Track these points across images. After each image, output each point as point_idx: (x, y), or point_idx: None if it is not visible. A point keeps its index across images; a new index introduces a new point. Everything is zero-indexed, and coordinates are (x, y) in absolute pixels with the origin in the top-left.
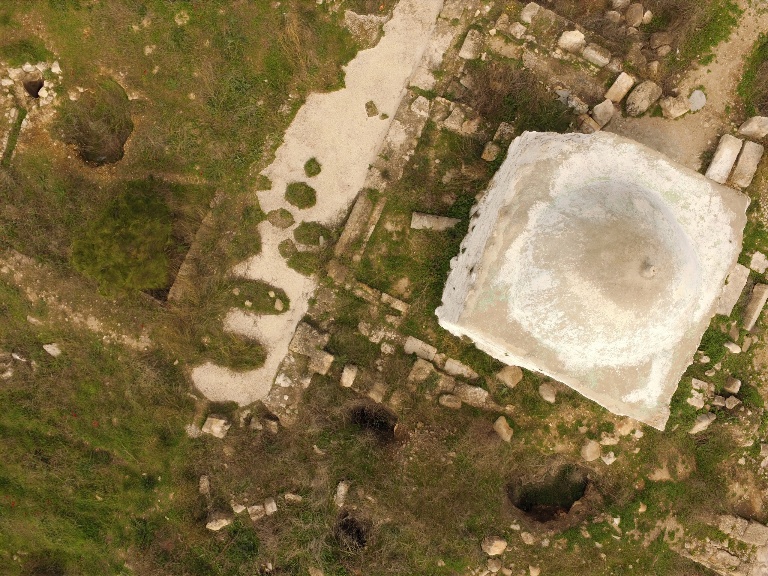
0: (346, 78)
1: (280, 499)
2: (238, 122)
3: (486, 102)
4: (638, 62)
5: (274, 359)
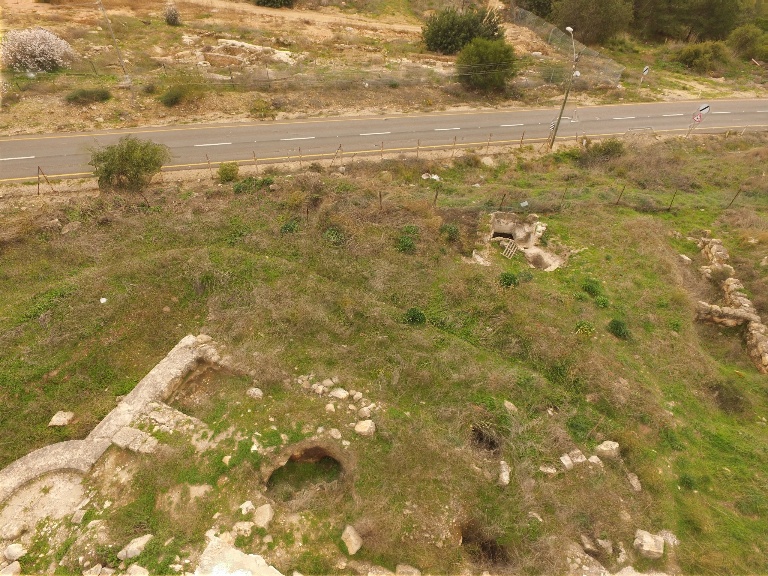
0: None
1: (561, 468)
2: None
3: None
4: None
5: None
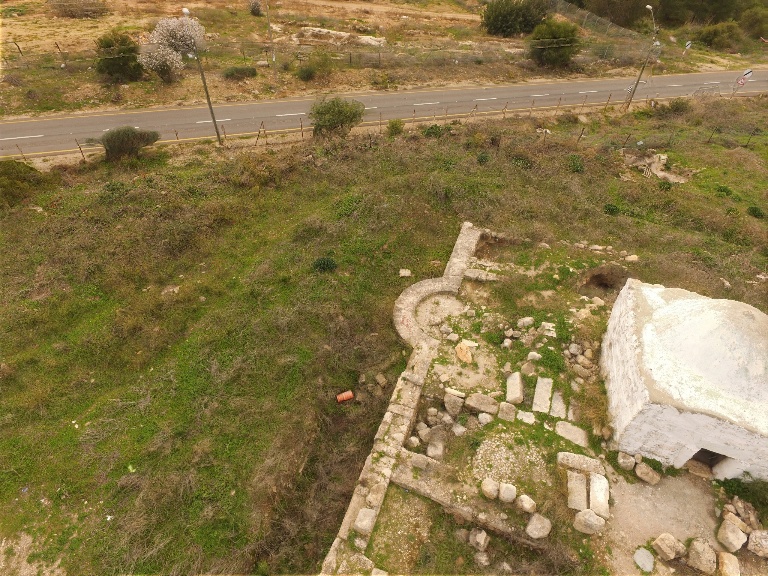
0: None
1: None
2: None
3: None
4: None
5: None
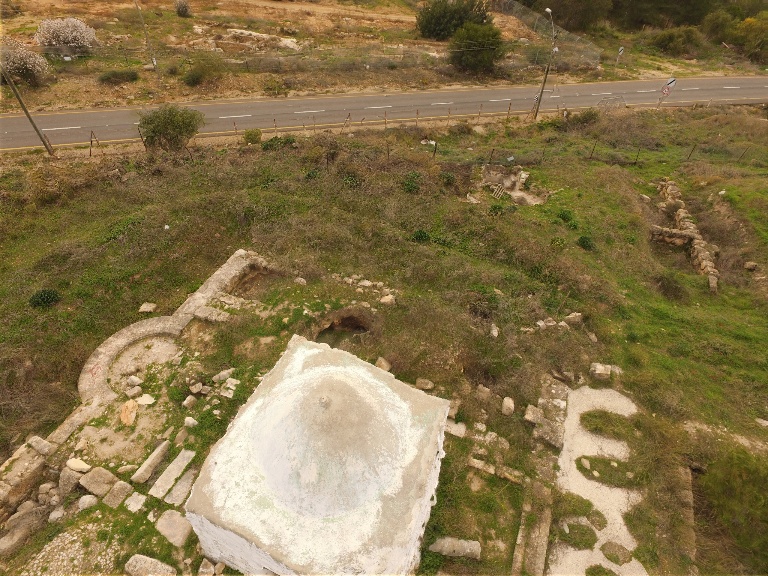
0: None
1: (537, 327)
2: None
3: None
4: None
5: (573, 420)
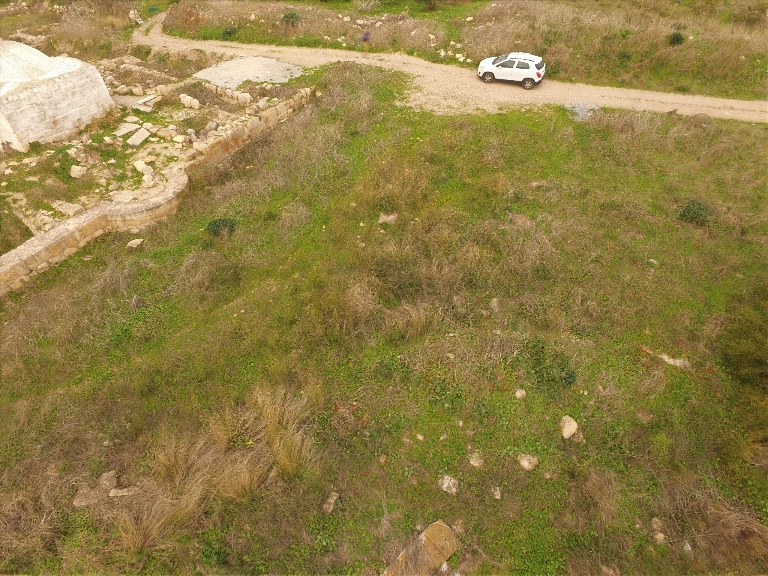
0: None
1: None
2: None
3: None
4: None
5: None
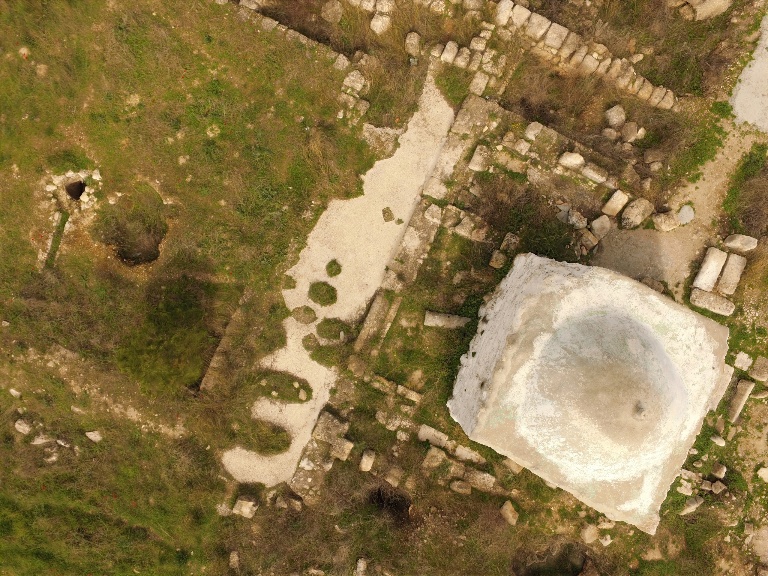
0: (364, 186)
1: (304, 575)
2: (265, 226)
3: (493, 210)
4: (632, 180)
5: (298, 444)
